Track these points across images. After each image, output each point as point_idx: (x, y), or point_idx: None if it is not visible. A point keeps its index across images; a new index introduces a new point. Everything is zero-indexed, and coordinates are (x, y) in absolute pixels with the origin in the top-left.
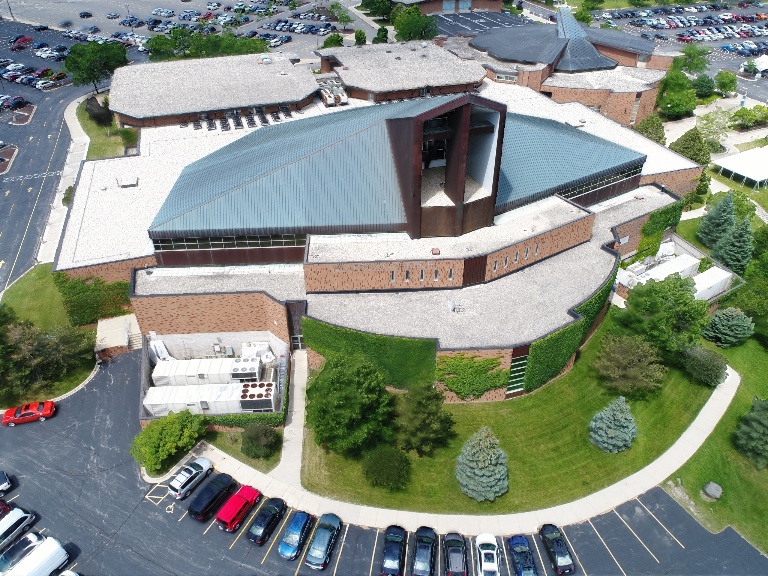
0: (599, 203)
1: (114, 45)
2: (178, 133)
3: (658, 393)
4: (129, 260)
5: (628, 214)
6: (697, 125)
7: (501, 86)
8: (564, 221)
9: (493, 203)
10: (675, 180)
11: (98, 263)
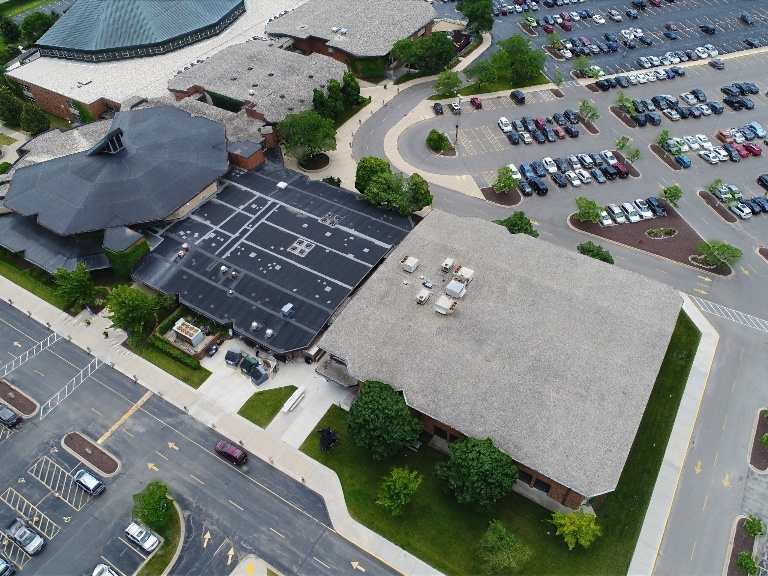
0: None
1: (477, 4)
2: None
3: None
4: None
5: None
6: None
7: None
8: None
9: None
10: None
11: None
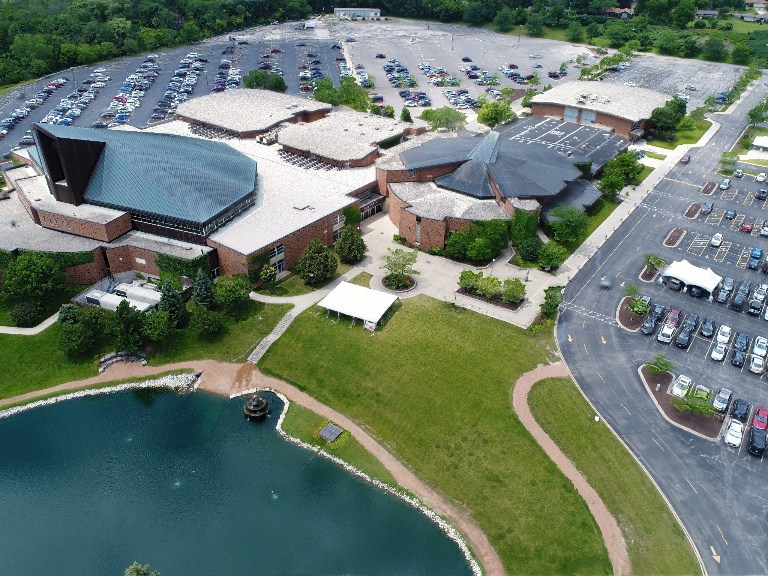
0: (171, 239)
1: (275, 76)
2: (180, 127)
3: (7, 310)
4: (25, 159)
5: (158, 249)
6: (390, 256)
7: (367, 173)
8: (91, 220)
9: (71, 191)
10: (230, 256)
11: (20, 155)
